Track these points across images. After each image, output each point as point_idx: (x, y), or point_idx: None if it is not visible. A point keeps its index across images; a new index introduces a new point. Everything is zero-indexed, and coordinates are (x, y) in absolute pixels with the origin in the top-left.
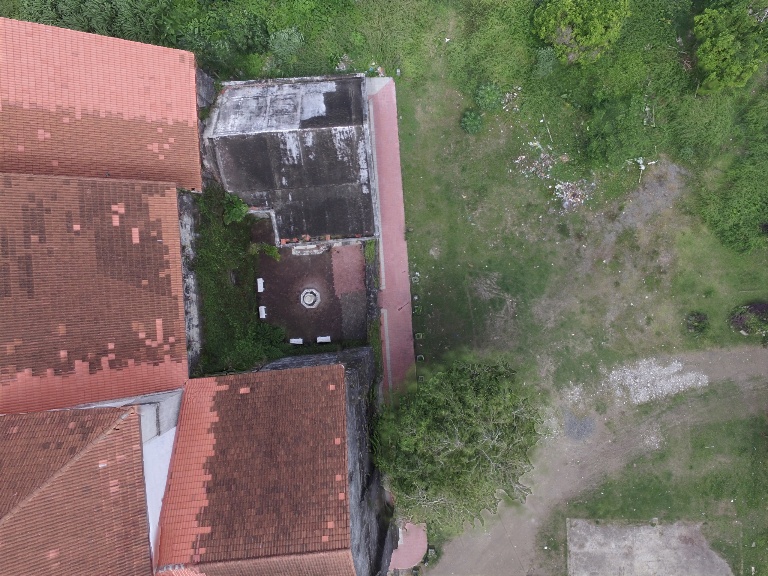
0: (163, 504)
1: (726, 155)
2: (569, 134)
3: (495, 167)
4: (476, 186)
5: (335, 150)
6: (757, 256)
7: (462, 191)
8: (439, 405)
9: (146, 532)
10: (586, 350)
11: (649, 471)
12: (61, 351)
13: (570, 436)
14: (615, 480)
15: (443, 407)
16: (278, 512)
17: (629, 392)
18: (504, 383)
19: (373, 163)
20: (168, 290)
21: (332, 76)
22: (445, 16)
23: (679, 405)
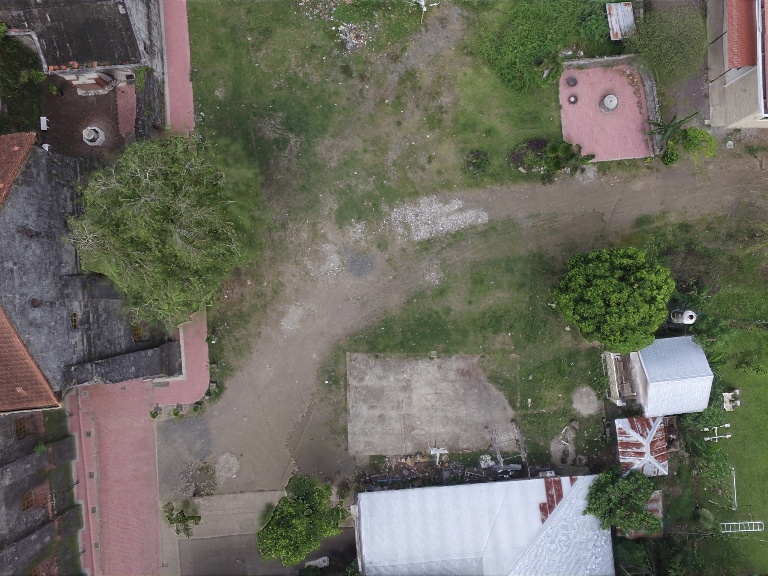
0: None
1: None
2: None
3: (279, 9)
4: (260, 28)
5: None
6: (537, 96)
7: (247, 33)
8: None
9: None
10: (368, 188)
11: (429, 306)
12: None
13: (352, 273)
14: (395, 315)
15: None
16: None
17: (410, 229)
18: (287, 221)
19: (159, 5)
20: None
21: None
22: None
23: (459, 241)
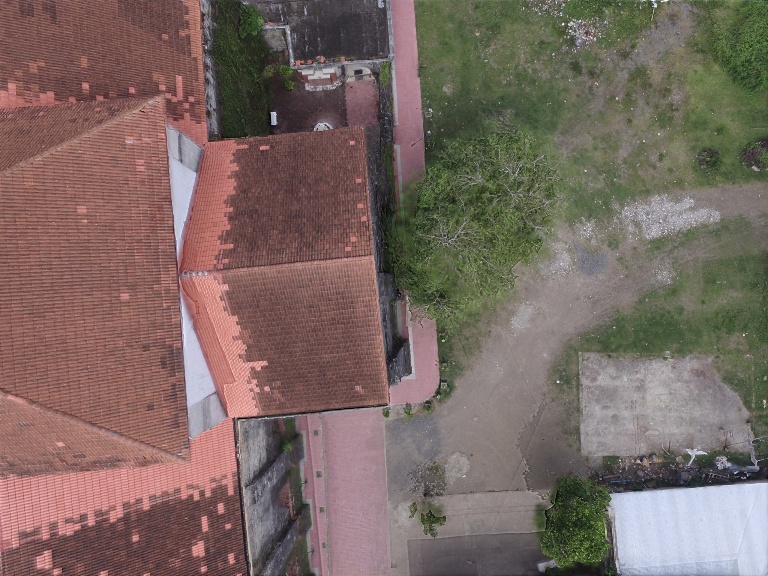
0: (185, 226)
1: None
2: None
3: (508, 5)
4: (489, 23)
5: None
6: None
7: (475, 29)
8: (458, 166)
9: (171, 220)
10: (598, 186)
11: (661, 306)
12: (83, 83)
13: (582, 271)
14: (627, 315)
15: (462, 164)
16: (300, 232)
17: (641, 228)
18: None
19: None
20: (188, 50)
21: None
22: None
23: (691, 241)
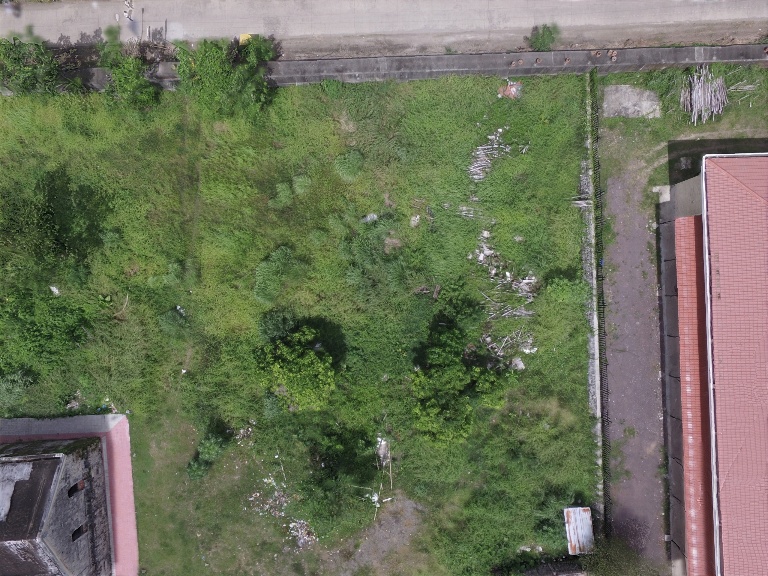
0: None
1: (462, 491)
2: (302, 473)
3: (229, 505)
4: (210, 525)
5: (16, 555)
6: None
7: (197, 529)
8: None
9: None
10: None
11: None
12: None
13: None
14: None
15: None
16: None
17: None
18: None
19: (106, 503)
20: None
21: (31, 457)
22: (181, 347)
23: None
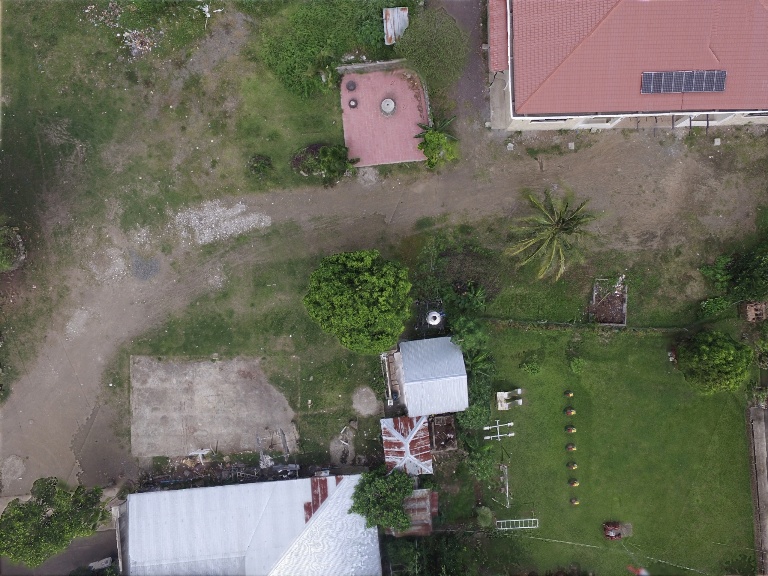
0: None
1: (290, 2)
2: None
3: (65, 16)
4: (46, 35)
5: None
6: (319, 100)
7: (34, 40)
8: None
9: None
10: (153, 193)
11: (212, 309)
12: None
13: (136, 276)
14: (179, 318)
15: None
16: None
17: (194, 233)
18: (72, 226)
19: None
20: None
21: None
22: None
23: (242, 245)
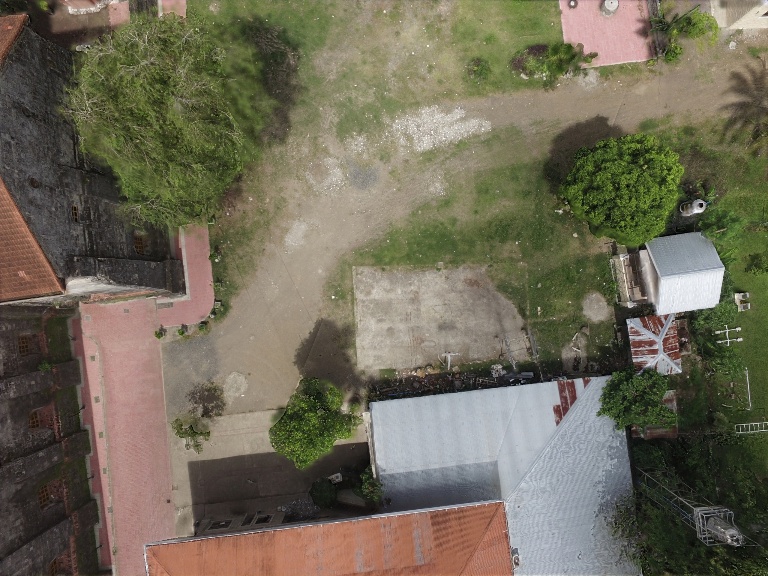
0: None
1: None
2: None
3: None
4: None
5: None
6: (537, 1)
7: None
8: None
9: None
10: (369, 101)
11: (434, 217)
12: None
13: (355, 186)
14: (400, 227)
15: None
16: None
17: (413, 140)
18: (287, 136)
19: None
20: None
21: None
22: None
23: (462, 151)
